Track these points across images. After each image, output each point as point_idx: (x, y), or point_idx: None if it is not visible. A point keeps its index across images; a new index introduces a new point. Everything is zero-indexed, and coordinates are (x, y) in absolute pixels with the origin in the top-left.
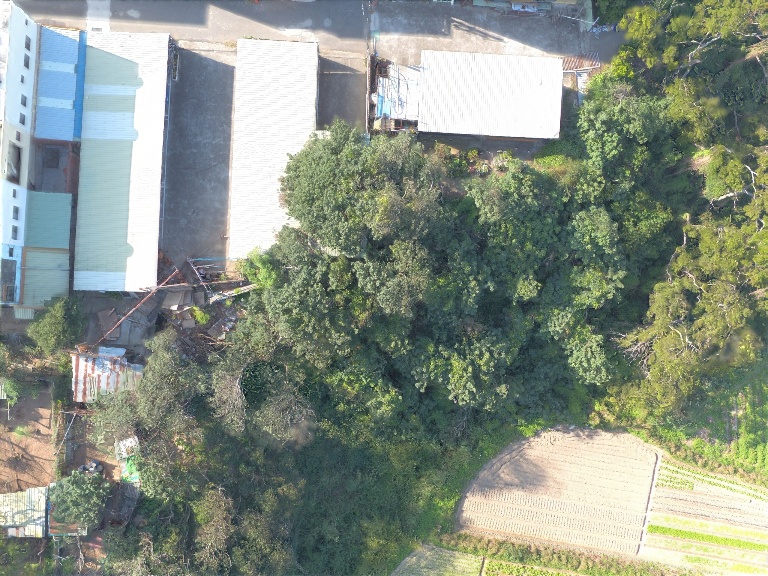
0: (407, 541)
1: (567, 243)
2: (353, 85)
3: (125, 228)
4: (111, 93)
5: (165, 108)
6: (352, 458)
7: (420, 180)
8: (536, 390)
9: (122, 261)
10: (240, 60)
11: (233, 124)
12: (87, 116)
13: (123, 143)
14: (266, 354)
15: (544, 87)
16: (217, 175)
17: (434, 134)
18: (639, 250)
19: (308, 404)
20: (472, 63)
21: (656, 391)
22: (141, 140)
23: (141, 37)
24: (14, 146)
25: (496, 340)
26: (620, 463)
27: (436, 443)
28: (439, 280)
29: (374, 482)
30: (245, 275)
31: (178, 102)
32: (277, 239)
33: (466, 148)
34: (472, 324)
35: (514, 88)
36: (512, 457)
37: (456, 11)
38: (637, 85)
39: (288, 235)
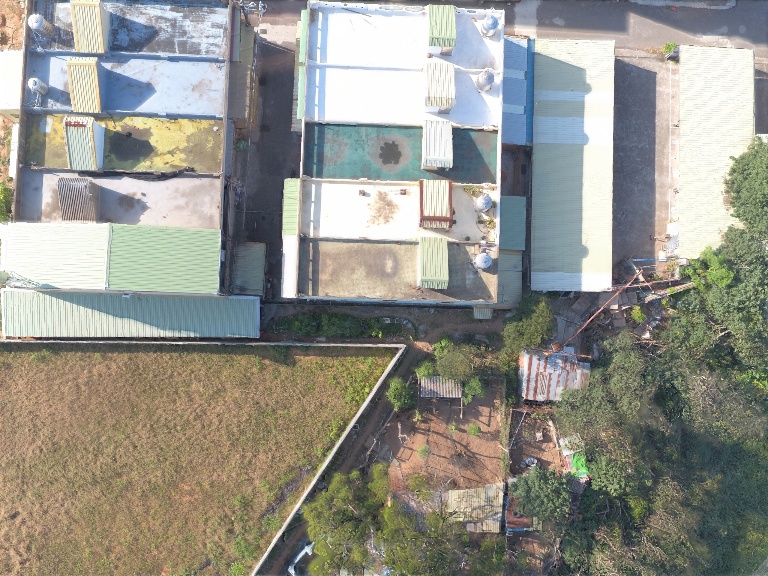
0: None
1: None
2: None
3: (579, 230)
4: (560, 99)
5: (613, 113)
6: (725, 454)
7: None
8: None
9: (578, 262)
10: (683, 66)
11: (657, 128)
12: (538, 121)
13: (573, 147)
14: (701, 352)
15: None
16: (644, 178)
17: None
18: None
19: (742, 400)
20: None
21: None
22: (591, 144)
23: (586, 44)
24: None
25: None
26: None
27: None
28: None
29: (741, 478)
30: (682, 275)
31: None
32: (723, 240)
33: None
34: None
35: None
36: None
37: None
38: None
39: (740, 236)
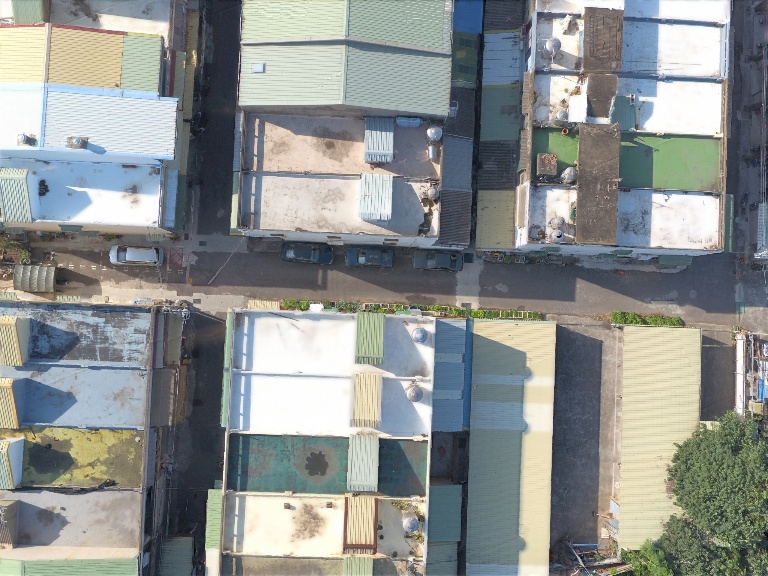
0: None
1: None
2: (720, 358)
3: (516, 520)
4: (499, 383)
5: (553, 398)
6: None
7: None
8: None
9: (514, 554)
10: (627, 349)
11: (602, 399)
12: (475, 406)
13: (511, 433)
14: None
15: None
16: (587, 451)
17: None
18: None
19: None
20: None
21: None
22: (530, 431)
23: (527, 325)
24: None
25: None
26: None
27: None
28: None
29: None
30: (624, 558)
31: None
32: (665, 529)
33: None
34: None
35: None
36: None
37: None
38: None
39: (681, 529)
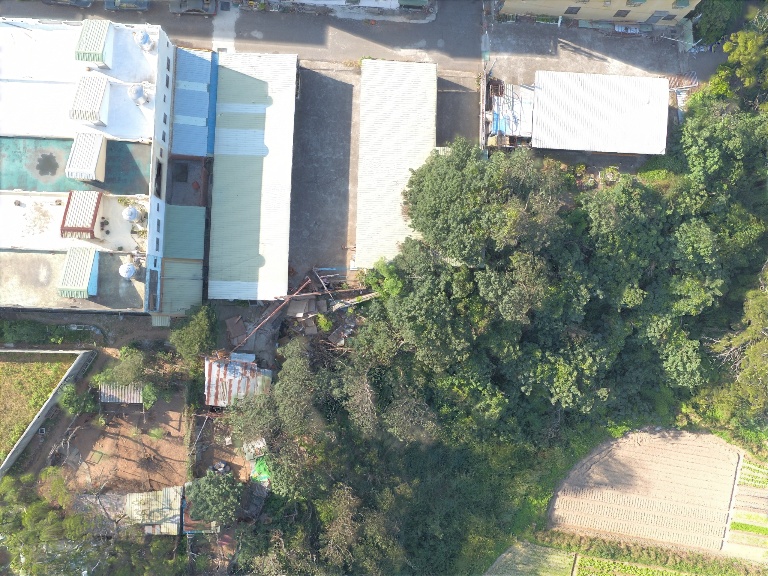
0: (505, 538)
1: (668, 253)
2: (465, 103)
3: (257, 240)
4: (242, 111)
5: None
6: (452, 458)
7: (539, 194)
8: (628, 393)
9: (254, 271)
10: (364, 80)
11: (352, 140)
12: (219, 133)
13: (254, 159)
14: (386, 359)
15: (651, 106)
16: (337, 189)
17: (543, 150)
18: (732, 259)
19: (426, 407)
20: (584, 83)
21: (748, 394)
22: (271, 156)
23: (270, 58)
24: (158, 162)
25: (597, 345)
26: (704, 463)
27: (530, 444)
28: (550, 289)
29: (472, 481)
30: (367, 284)
31: (300, 119)
32: (400, 250)
33: (573, 163)
34: (576, 330)
35: (623, 106)
36: (601, 457)
37: (562, 32)
38: (732, 103)
39: (412, 246)
